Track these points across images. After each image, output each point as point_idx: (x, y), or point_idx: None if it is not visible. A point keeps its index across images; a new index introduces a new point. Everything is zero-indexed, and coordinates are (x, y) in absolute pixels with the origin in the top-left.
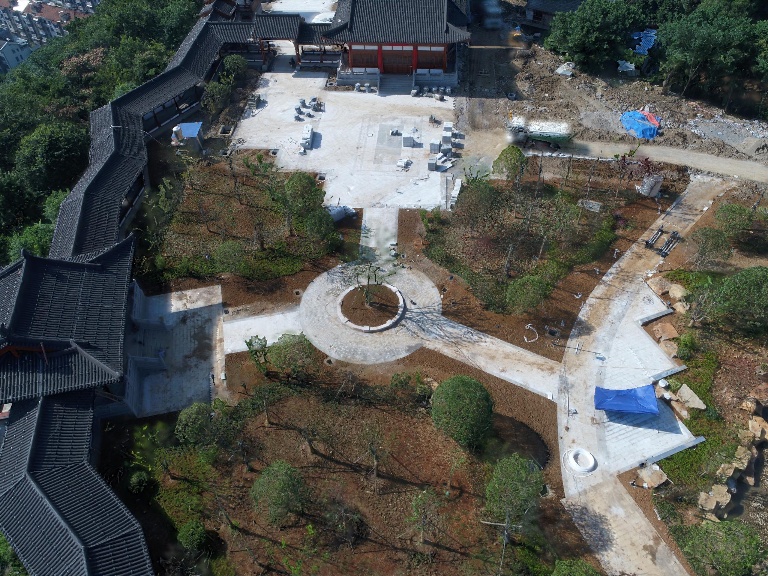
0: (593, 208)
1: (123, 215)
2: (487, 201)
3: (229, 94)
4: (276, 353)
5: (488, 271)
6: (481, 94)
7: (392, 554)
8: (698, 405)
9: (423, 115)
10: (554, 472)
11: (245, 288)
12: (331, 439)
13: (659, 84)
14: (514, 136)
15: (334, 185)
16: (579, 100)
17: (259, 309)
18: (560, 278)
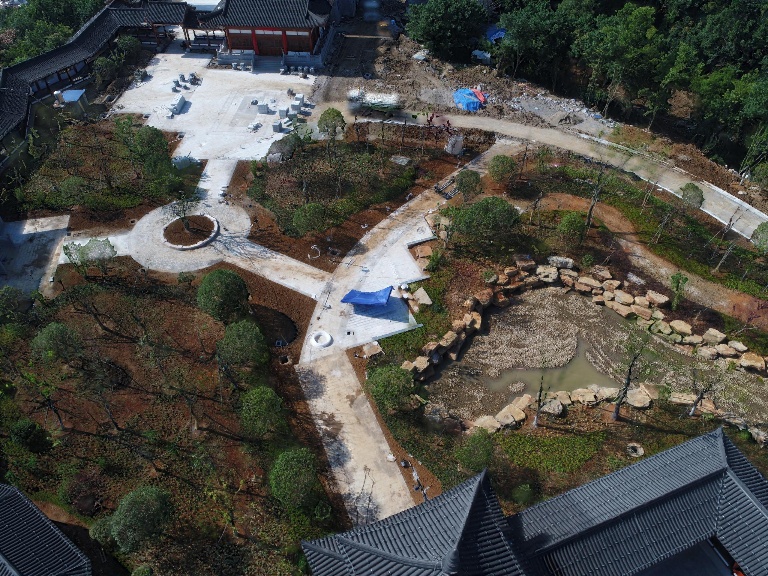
0: (402, 162)
1: (0, 161)
2: (290, 147)
3: (120, 70)
4: (82, 253)
5: (294, 206)
6: (342, 74)
7: (143, 396)
8: (426, 301)
9: (285, 89)
10: (296, 347)
11: (89, 217)
12: (122, 321)
13: (508, 71)
14: (357, 107)
15: (189, 142)
16: (423, 79)
17: (97, 233)
18: (353, 213)
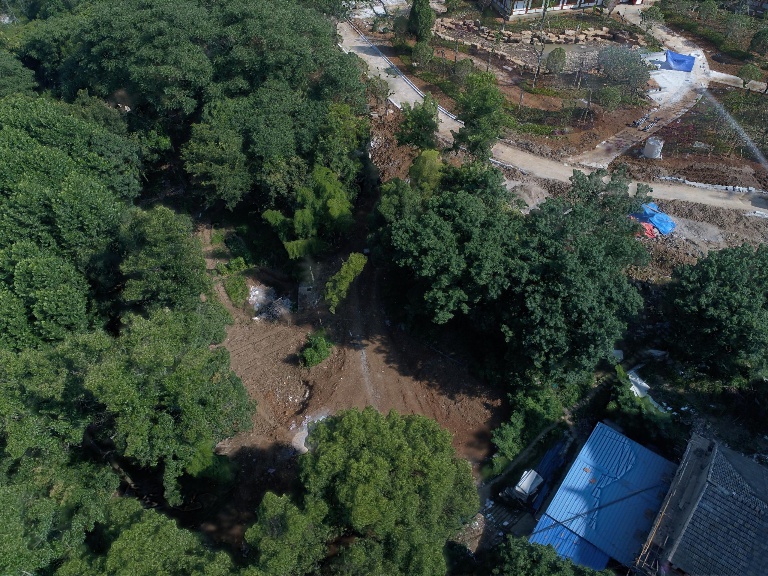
0: (700, 144)
1: None
2: None
3: None
4: None
5: None
6: None
7: None
8: None
9: None
10: None
11: None
12: None
13: None
14: None
15: None
16: None
17: None
18: None
